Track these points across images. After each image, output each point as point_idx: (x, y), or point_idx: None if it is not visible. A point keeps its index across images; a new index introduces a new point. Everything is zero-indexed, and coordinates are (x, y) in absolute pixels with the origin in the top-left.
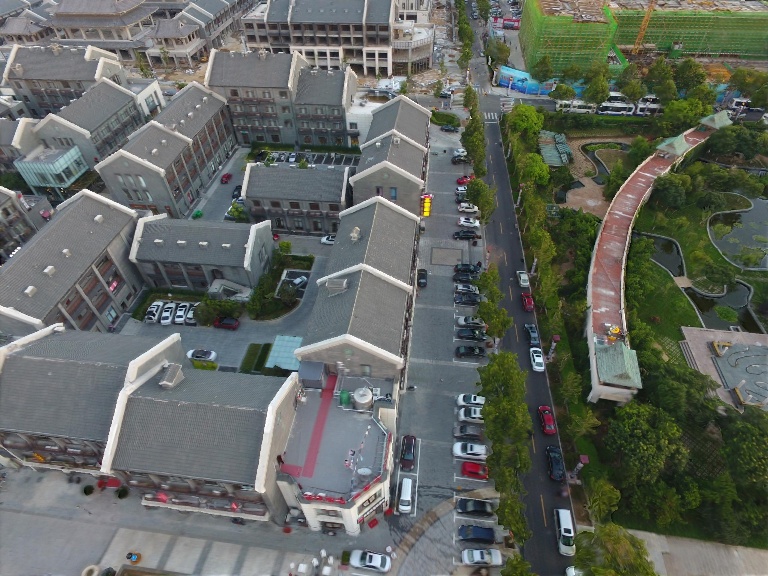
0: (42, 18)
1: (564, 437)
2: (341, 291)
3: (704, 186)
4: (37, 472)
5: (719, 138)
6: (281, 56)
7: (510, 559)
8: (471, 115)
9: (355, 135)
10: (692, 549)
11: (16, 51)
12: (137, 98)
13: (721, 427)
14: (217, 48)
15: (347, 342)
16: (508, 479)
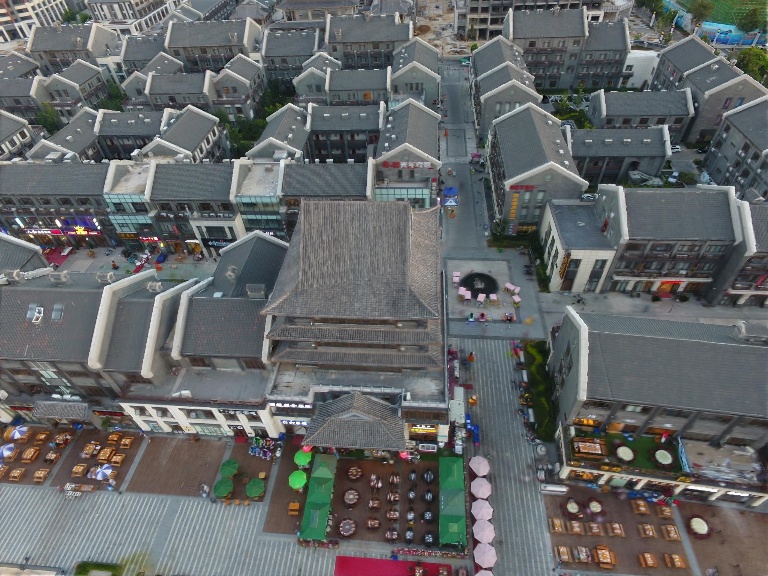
0: (262, 5)
1: None
2: None
3: None
4: (599, 293)
5: None
6: (571, 11)
7: None
8: None
9: (628, 76)
10: None
11: (330, 20)
12: None
13: None
14: (415, 25)
15: None
16: None
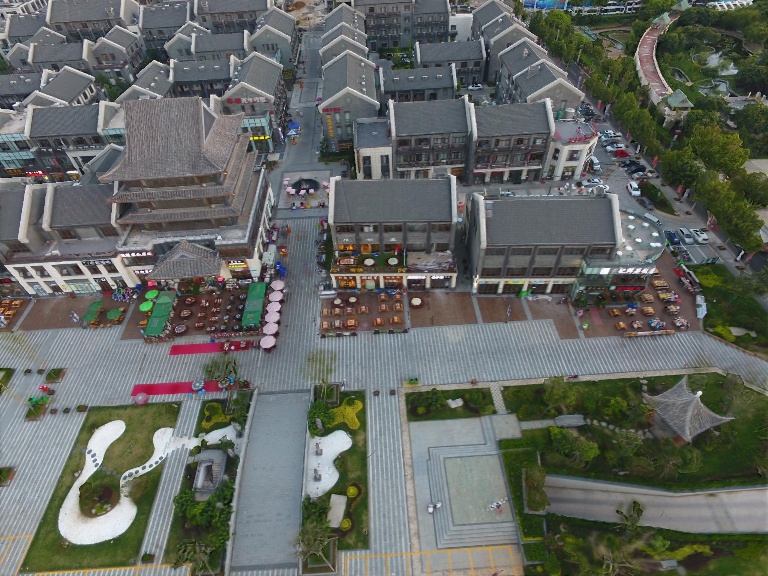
0: None
1: (659, 139)
2: (536, 73)
3: (686, 39)
4: None
5: (686, 15)
6: None
7: (664, 155)
8: (523, 19)
9: (454, 35)
10: None
11: None
12: (295, 21)
13: (734, 121)
14: (292, 2)
15: (560, 82)
16: (651, 131)
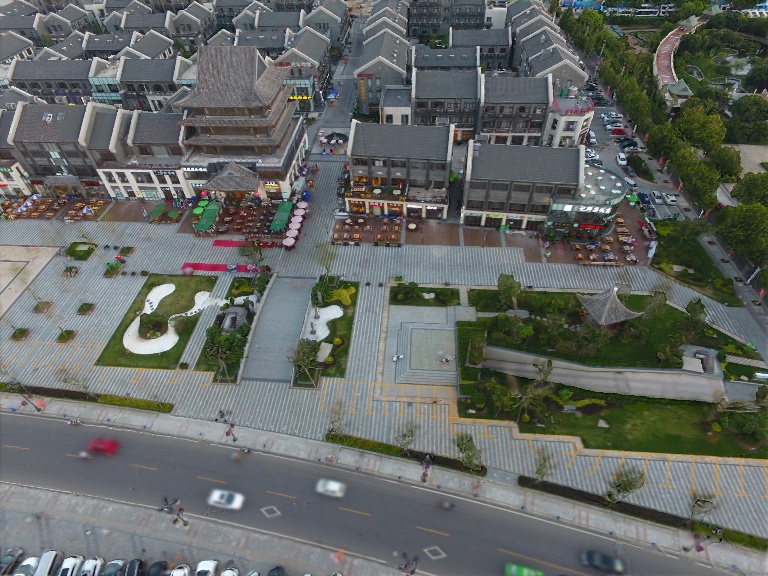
0: None
1: (657, 122)
2: (548, 56)
3: (709, 40)
4: None
5: (715, 19)
6: None
7: None
8: (557, 16)
9: (489, 26)
10: (722, 146)
11: None
12: None
13: None
14: None
15: (566, 63)
16: (645, 111)
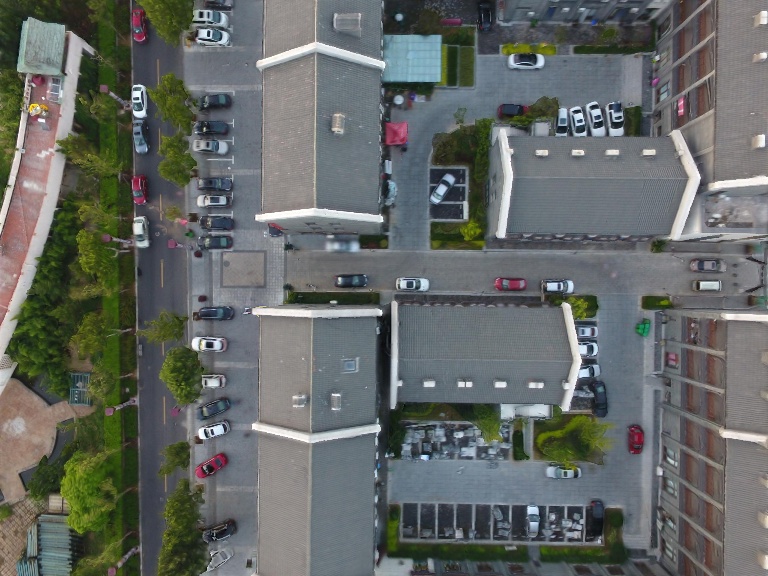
0: None
1: (125, 6)
2: None
3: None
4: None
5: None
6: None
7: None
8: None
9: (420, 573)
10: None
11: None
12: None
13: None
14: None
15: None
16: None
